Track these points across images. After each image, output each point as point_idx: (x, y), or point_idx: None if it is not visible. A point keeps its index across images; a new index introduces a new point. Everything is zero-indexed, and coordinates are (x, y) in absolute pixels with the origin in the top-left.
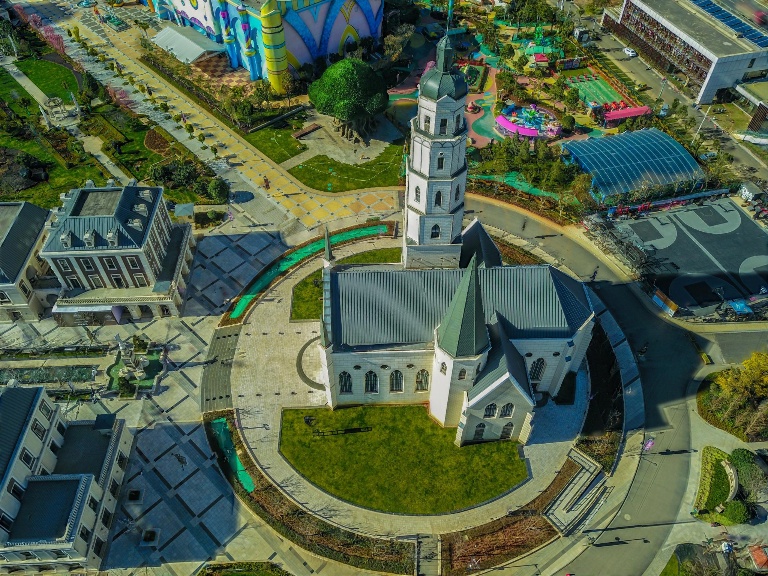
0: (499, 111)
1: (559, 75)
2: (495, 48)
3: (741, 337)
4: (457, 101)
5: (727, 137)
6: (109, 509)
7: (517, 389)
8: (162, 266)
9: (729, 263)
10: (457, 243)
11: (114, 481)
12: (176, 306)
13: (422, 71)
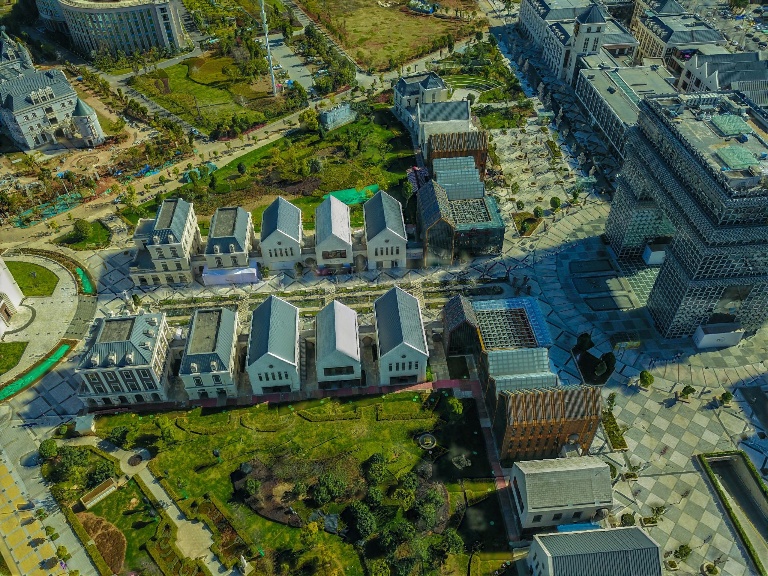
0: None
1: None
2: None
3: None
4: None
5: None
6: None
7: None
8: None
9: None
10: None
11: None
12: None
13: None
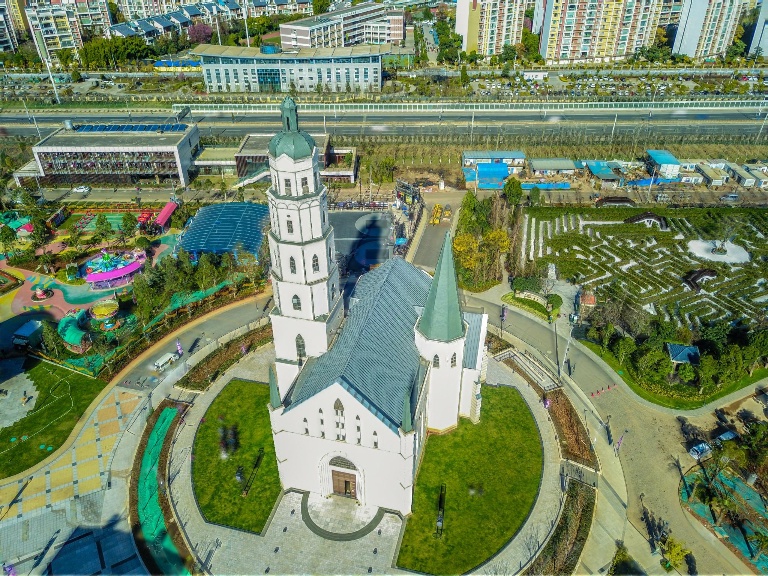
0: (72, 278)
1: (64, 230)
2: None
3: (420, 255)
4: None
5: (232, 191)
6: None
7: None
8: None
9: (355, 235)
10: (341, 292)
11: None
12: None
13: None
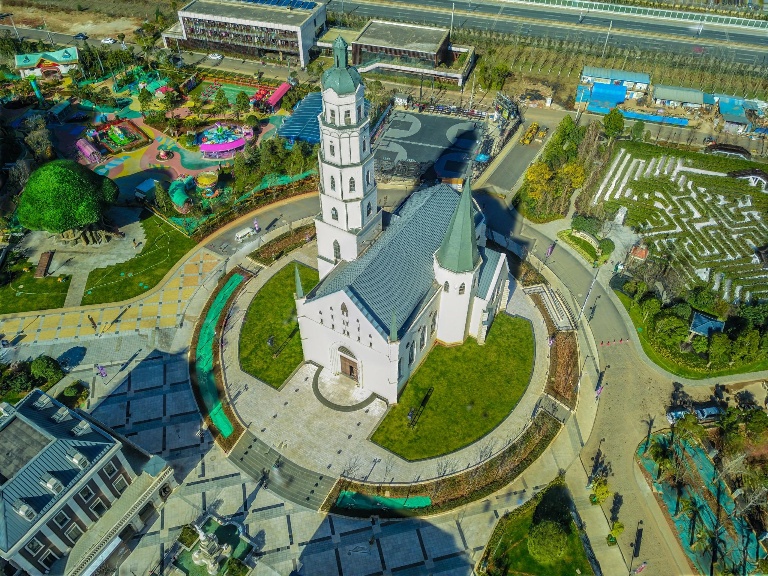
0: (190, 144)
1: None
2: (116, 102)
3: (497, 174)
4: None
5: None
6: None
7: (506, 263)
8: None
9: (443, 143)
10: (380, 210)
11: None
12: None
13: (75, 154)
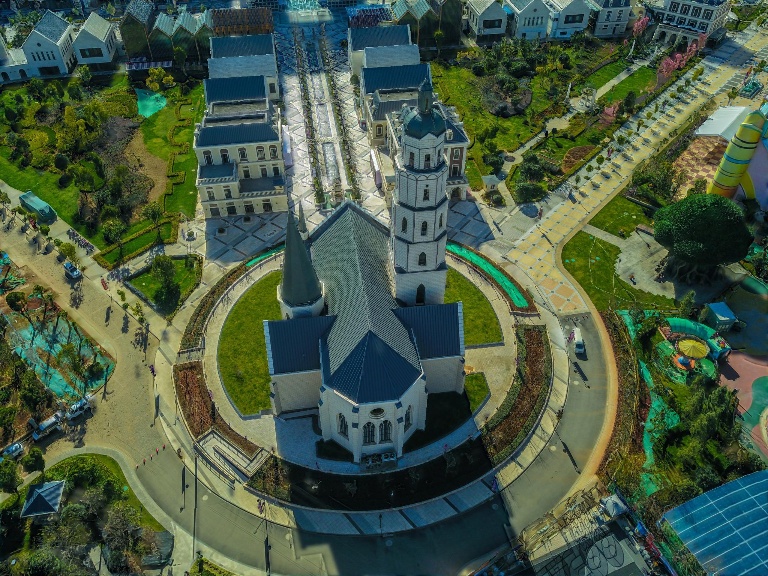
0: None
1: None
2: None
3: None
4: (406, 135)
5: None
6: (237, 210)
7: None
8: None
9: None
10: (396, 270)
11: (253, 207)
12: None
13: None
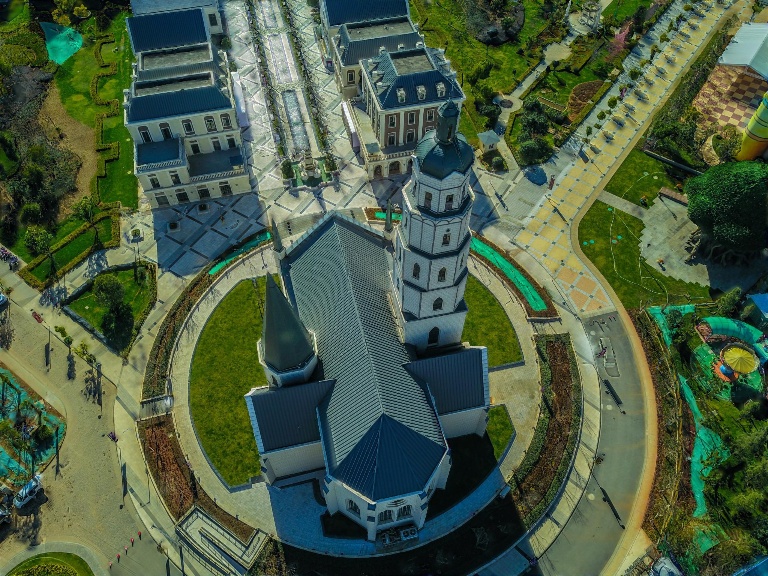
0: None
1: None
2: None
3: None
4: (421, 173)
5: None
6: (189, 196)
7: None
8: (405, 144)
9: None
10: (404, 317)
11: (208, 191)
12: (374, 172)
13: None
